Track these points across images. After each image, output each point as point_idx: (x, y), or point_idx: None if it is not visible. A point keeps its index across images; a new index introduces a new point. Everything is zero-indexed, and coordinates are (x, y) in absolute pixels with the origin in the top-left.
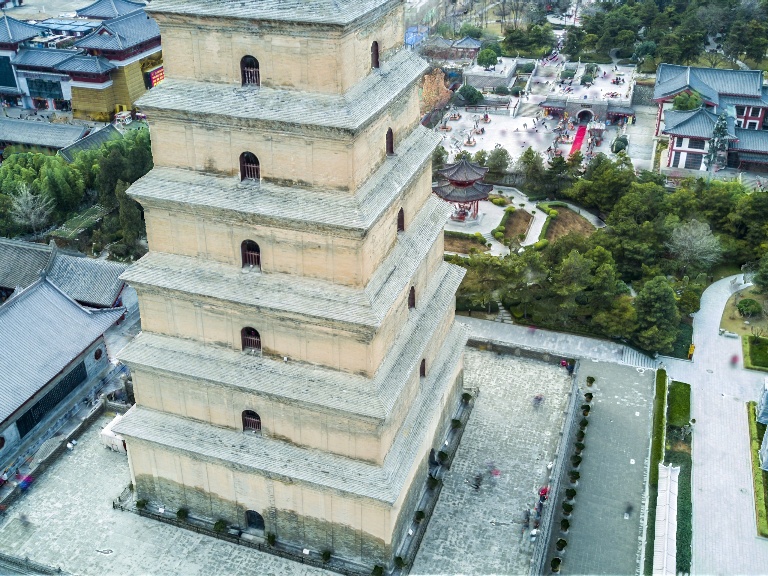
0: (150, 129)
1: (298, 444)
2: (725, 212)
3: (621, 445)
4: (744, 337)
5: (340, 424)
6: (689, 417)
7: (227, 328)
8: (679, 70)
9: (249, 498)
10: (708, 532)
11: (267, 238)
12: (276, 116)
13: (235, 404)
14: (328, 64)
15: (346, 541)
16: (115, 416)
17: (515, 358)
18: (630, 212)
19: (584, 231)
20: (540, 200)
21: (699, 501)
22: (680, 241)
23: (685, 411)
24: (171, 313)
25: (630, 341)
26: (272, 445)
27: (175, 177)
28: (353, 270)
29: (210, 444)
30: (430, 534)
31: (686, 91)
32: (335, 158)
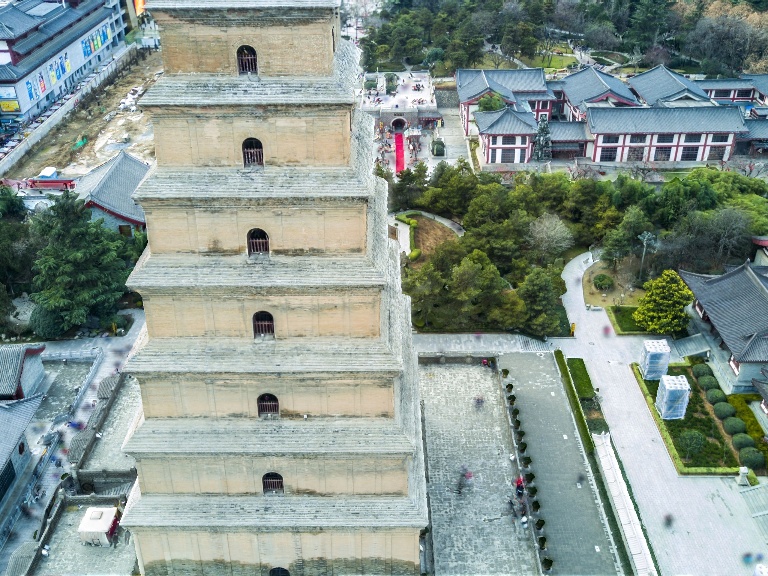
0: (146, 219)
1: (323, 494)
2: (559, 201)
3: (551, 424)
4: (607, 308)
5: (366, 466)
6: (592, 387)
7: (242, 399)
8: (474, 74)
9: (274, 557)
10: (642, 482)
11: (281, 307)
12: (288, 193)
13: (255, 470)
14: (334, 139)
15: (376, 572)
16: (78, 509)
17: (441, 366)
18: (486, 213)
19: (445, 235)
20: (395, 212)
21: (625, 458)
22: (538, 234)
23: (588, 383)
24: (179, 395)
25: (522, 330)
26: (296, 500)
27: (177, 262)
28: (370, 323)
29: (232, 514)
30: (438, 545)
31: (488, 93)
32: (347, 224)
